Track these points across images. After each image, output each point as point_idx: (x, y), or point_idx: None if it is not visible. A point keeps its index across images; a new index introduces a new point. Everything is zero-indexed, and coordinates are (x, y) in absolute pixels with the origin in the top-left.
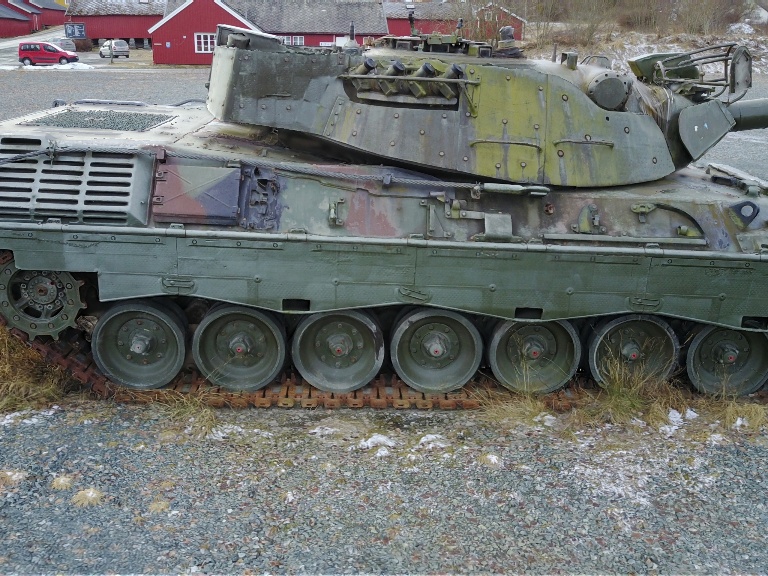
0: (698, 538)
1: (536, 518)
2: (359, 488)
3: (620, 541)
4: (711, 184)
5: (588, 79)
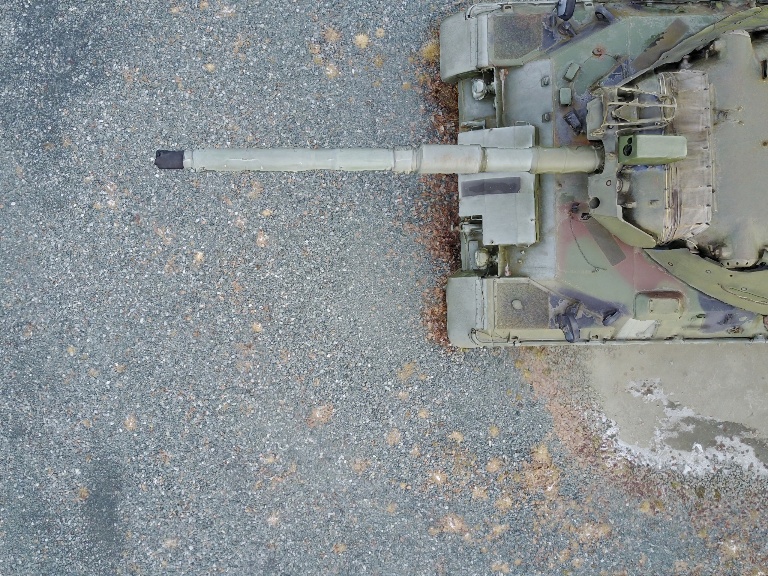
0: None
1: None
2: None
3: None
4: None
5: None
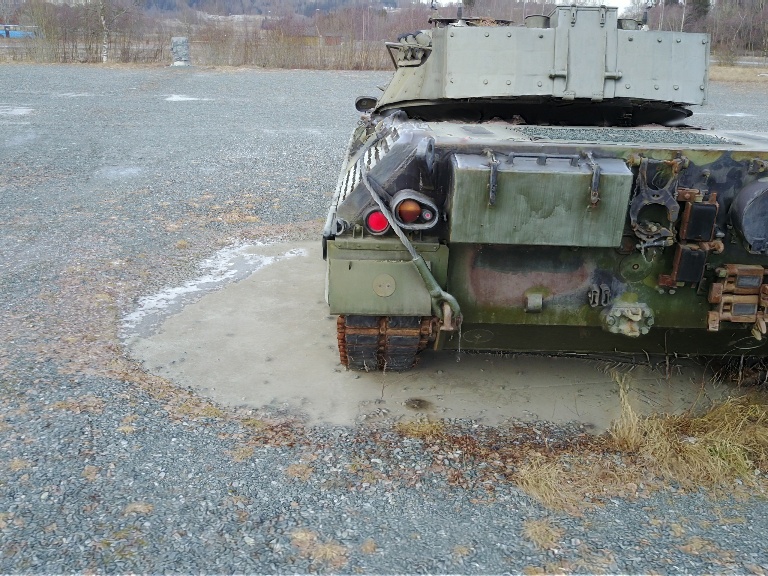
0: None
1: None
2: None
3: None
4: None
5: None
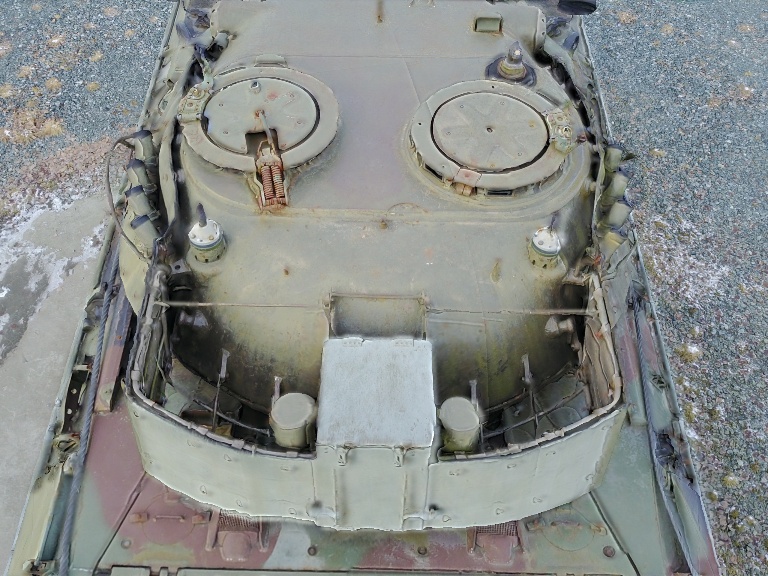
0: (761, 253)
1: (766, 337)
2: (764, 454)
3: None
4: None
5: (522, 35)
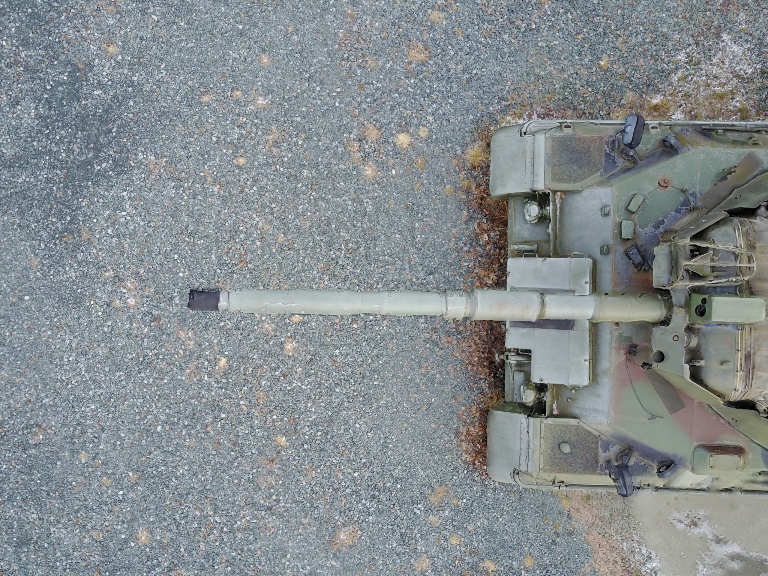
0: (710, 5)
1: None
2: None
3: (749, 4)
4: (657, 239)
5: None
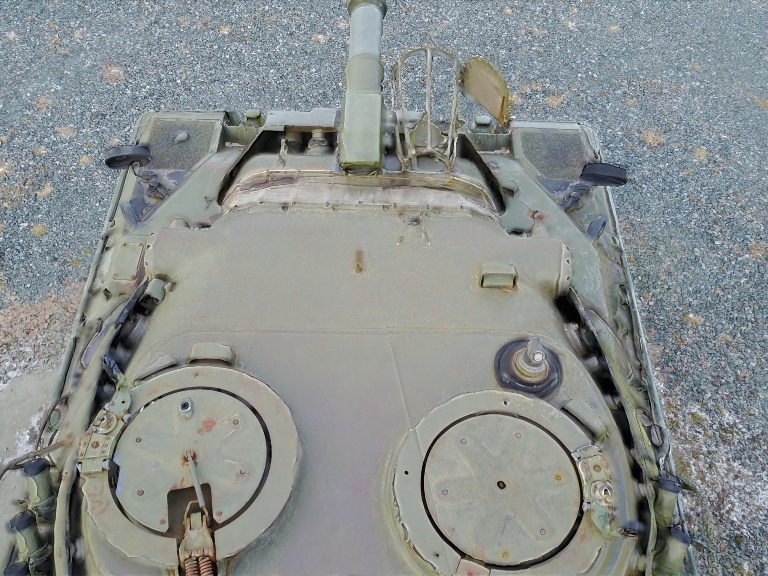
0: None
1: None
2: None
3: None
4: None
5: (541, 281)
